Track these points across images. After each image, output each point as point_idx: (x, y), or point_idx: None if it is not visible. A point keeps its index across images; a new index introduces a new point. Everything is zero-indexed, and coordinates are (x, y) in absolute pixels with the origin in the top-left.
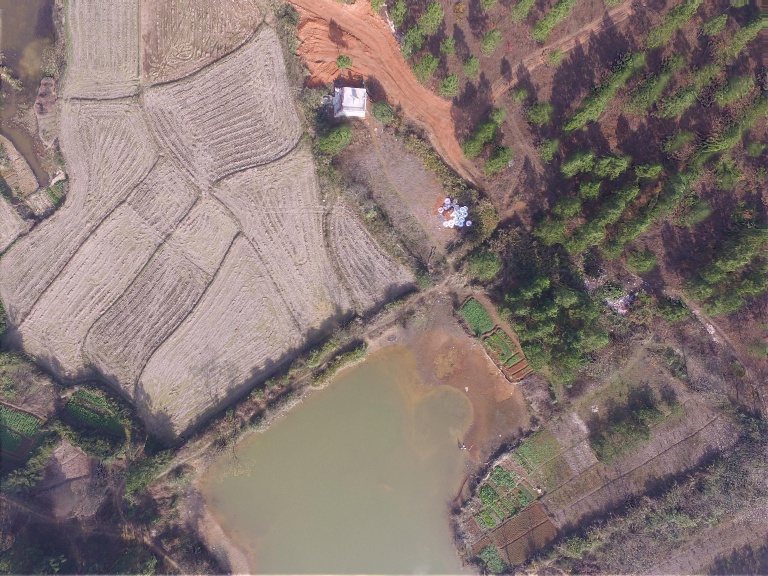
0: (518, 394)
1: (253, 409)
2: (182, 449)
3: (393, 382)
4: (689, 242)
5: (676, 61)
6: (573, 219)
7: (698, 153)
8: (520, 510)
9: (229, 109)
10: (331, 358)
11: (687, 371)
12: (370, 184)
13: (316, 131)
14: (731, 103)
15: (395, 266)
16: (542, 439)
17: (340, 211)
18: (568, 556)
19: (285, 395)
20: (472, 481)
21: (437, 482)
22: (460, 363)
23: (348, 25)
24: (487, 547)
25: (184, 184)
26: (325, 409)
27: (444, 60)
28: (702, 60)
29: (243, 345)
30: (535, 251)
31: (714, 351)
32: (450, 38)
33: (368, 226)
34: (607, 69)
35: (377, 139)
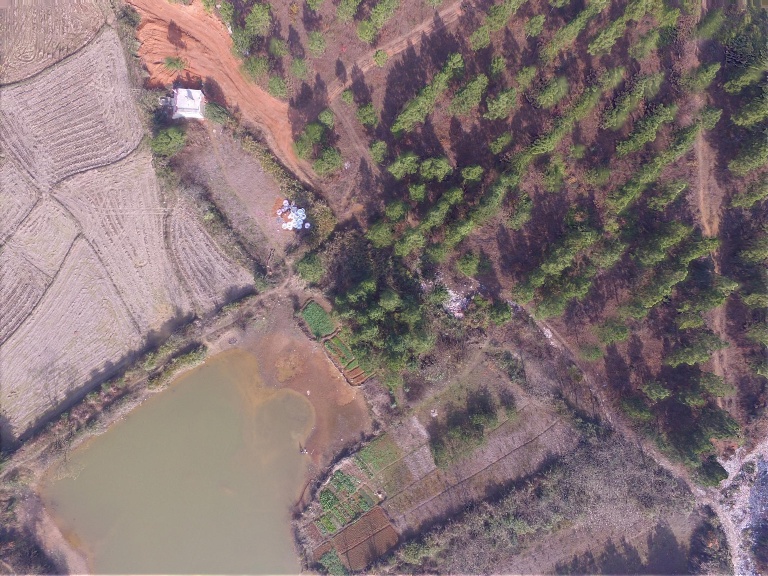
0: (360, 398)
1: (88, 412)
2: (18, 452)
3: (234, 385)
4: (523, 245)
5: (506, 62)
6: (399, 221)
7: (528, 155)
8: (360, 515)
9: (70, 110)
10: (168, 361)
11: (525, 375)
12: (209, 186)
13: (153, 132)
14: (561, 105)
15: (235, 268)
16: (382, 443)
17: (180, 213)
18: (408, 562)
19: (120, 398)
20: (313, 486)
21: (279, 486)
22: (302, 366)
23: (188, 26)
24: (328, 552)
25: (25, 185)
26: (166, 412)
27: (280, 61)
28: (531, 61)
29: (83, 347)
30: (369, 254)
31: (551, 355)
32: (286, 39)
33: (207, 228)
34: (439, 70)
35: (216, 141)
